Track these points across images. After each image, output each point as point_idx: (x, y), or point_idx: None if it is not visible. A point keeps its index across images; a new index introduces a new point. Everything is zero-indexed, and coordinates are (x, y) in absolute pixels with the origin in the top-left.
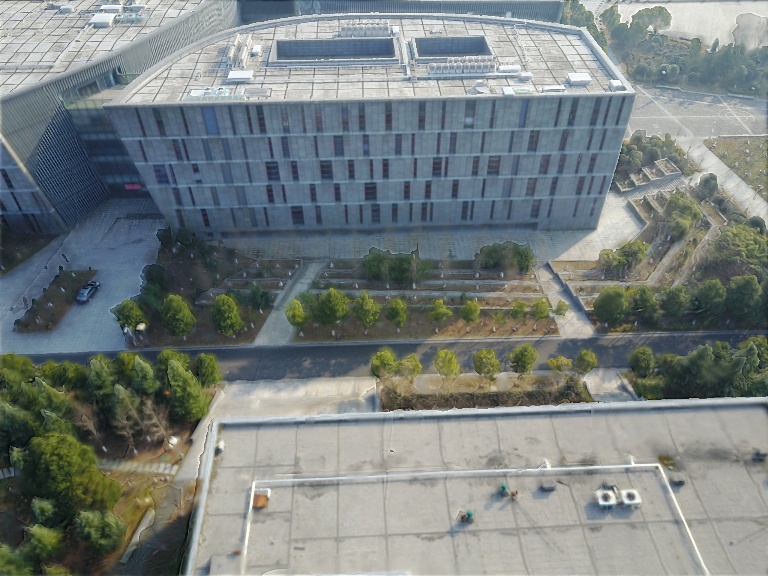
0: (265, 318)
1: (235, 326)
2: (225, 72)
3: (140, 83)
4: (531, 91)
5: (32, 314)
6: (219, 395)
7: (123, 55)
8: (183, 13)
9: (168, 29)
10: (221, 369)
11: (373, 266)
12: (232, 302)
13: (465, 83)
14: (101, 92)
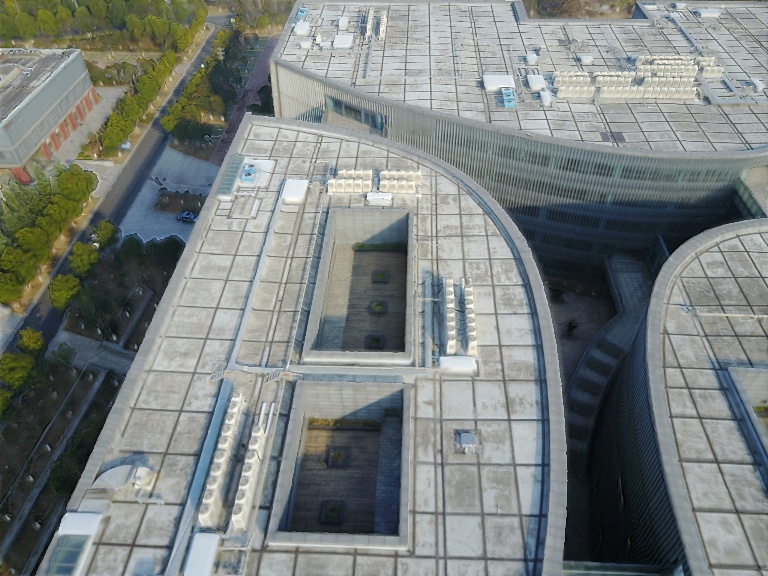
0: (90, 336)
1: (55, 302)
2: (321, 180)
3: (299, 126)
4: (54, 574)
5: (174, 195)
6: (1, 307)
7: (396, 110)
8: (536, 131)
9: (473, 127)
10: (43, 310)
11: (88, 422)
12: (56, 285)
13: (179, 458)
14: (363, 124)
